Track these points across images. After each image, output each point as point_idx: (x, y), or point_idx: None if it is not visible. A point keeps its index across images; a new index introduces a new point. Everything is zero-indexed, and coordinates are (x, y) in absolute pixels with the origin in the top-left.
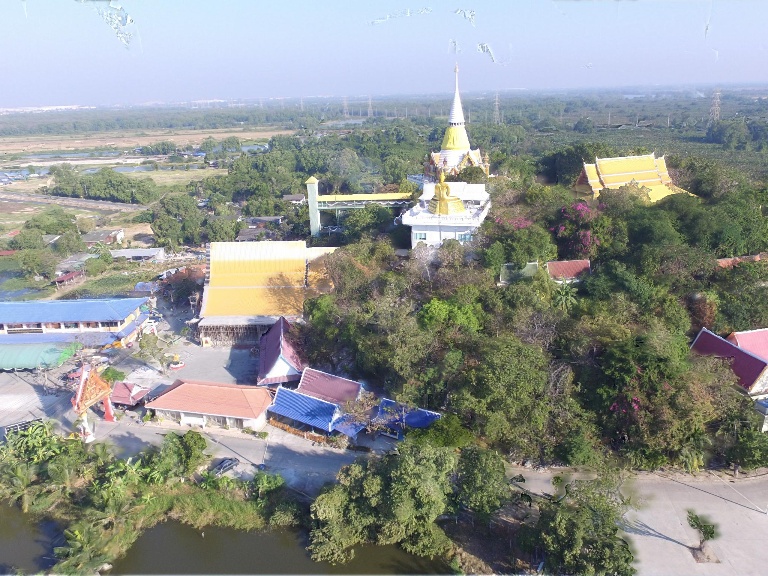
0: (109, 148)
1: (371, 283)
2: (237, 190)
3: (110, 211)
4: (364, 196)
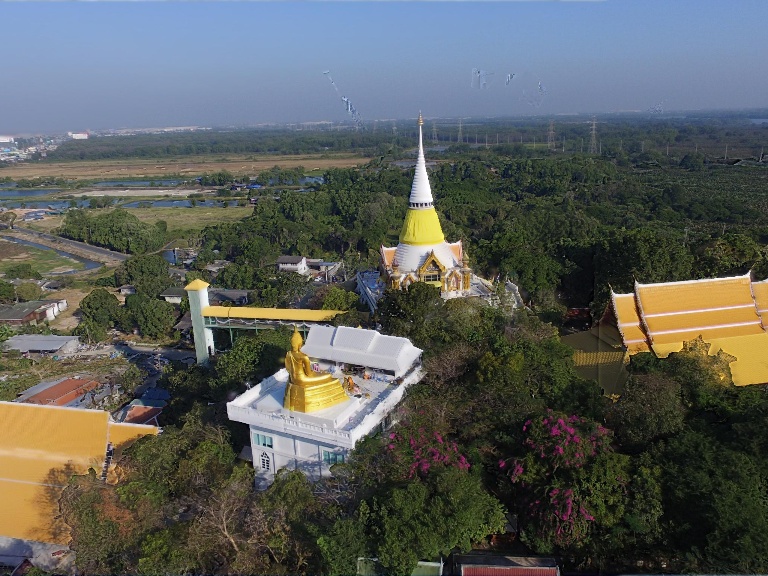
0: (177, 176)
1: (125, 553)
2: (236, 244)
3: (98, 263)
4: (269, 312)
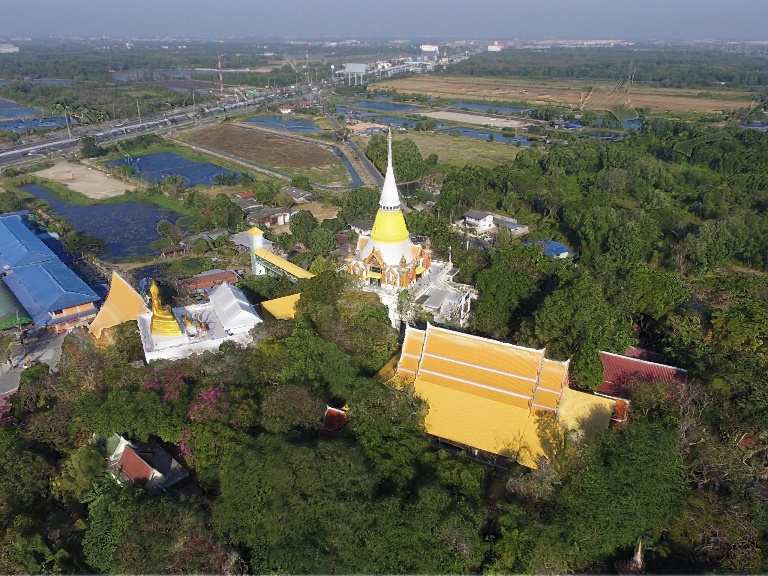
0: (522, 104)
1: None
2: None
3: (363, 184)
4: (282, 263)
